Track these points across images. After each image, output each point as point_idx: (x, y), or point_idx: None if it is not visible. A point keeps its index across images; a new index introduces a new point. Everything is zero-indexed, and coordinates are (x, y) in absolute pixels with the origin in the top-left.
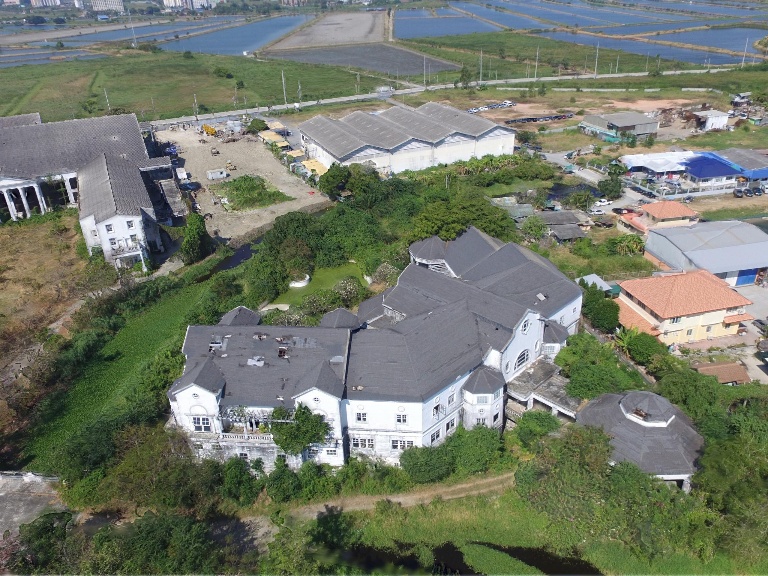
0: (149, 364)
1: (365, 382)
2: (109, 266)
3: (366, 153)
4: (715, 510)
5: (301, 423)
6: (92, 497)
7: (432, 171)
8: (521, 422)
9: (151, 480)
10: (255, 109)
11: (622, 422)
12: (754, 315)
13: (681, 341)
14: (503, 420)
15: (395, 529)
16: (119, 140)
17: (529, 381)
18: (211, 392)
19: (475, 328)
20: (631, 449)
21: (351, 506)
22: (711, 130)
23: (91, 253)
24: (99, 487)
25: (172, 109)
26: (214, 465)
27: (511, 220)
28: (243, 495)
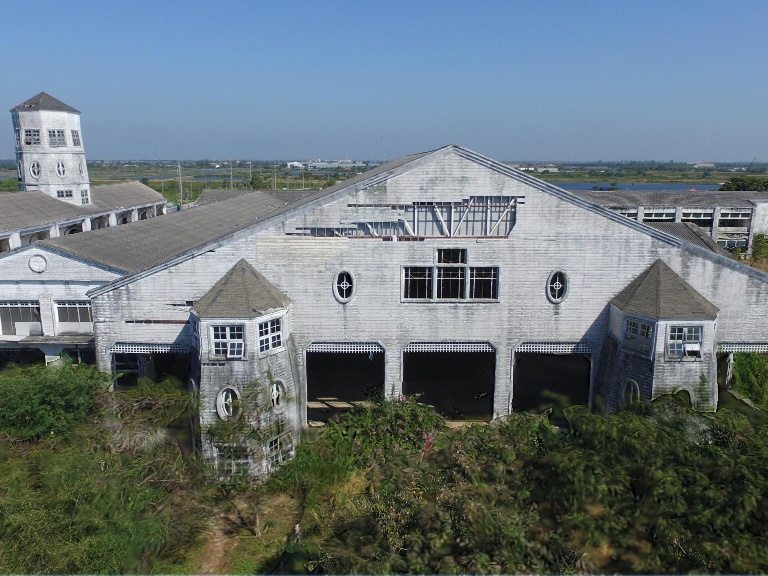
0: None
1: None
2: None
3: None
4: None
5: None
6: None
7: None
8: None
9: None
10: None
11: None
12: None
13: None
14: None
15: None
16: None
17: None
18: None
19: None
20: None
21: None
22: None
23: (750, 246)
24: None
25: None
26: None
27: None
28: None
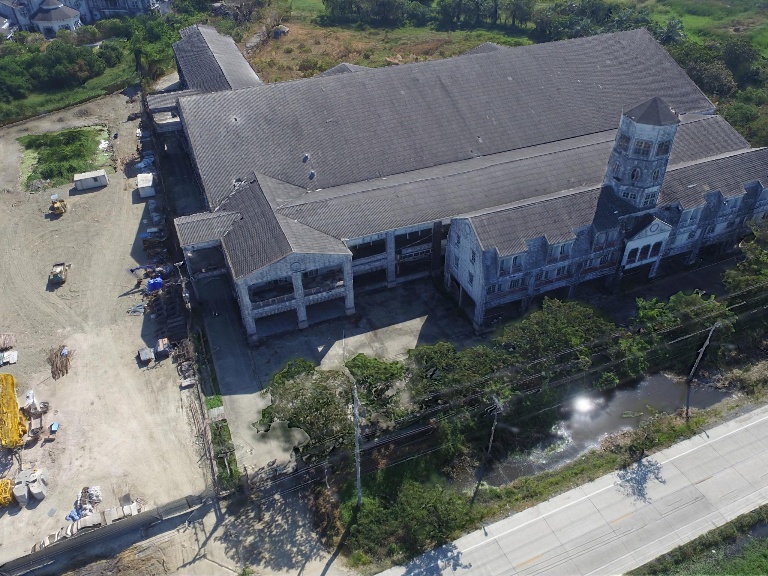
0: None
1: None
2: None
3: None
4: None
5: None
6: None
7: None
8: None
9: None
10: None
11: None
12: None
13: None
14: None
15: None
16: None
17: None
18: None
19: None
20: None
21: None
22: None
23: None
24: None
25: None
26: None
27: None
28: None
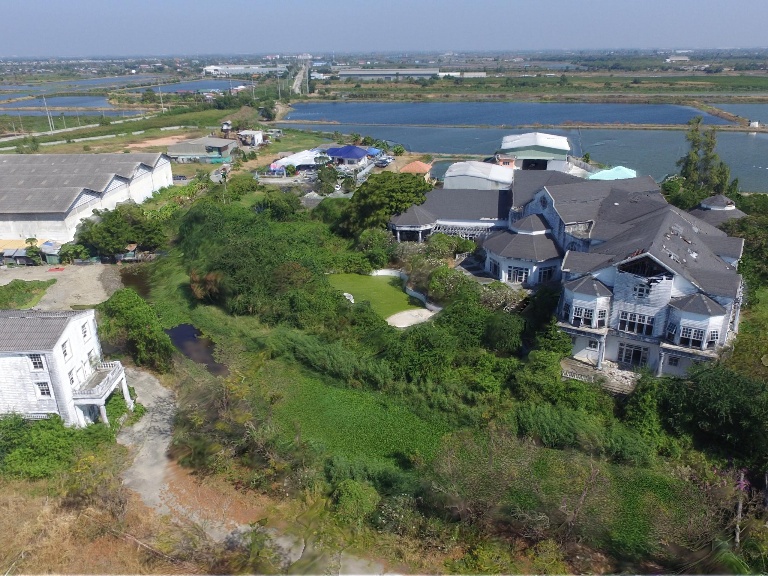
0: None
1: None
2: (81, 431)
3: (82, 201)
4: None
5: None
6: None
7: None
8: None
9: None
10: None
11: (727, 213)
12: None
13: None
14: None
15: None
16: None
17: None
18: None
19: None
20: None
21: None
22: (259, 145)
23: None
24: None
25: None
26: None
27: None
28: None
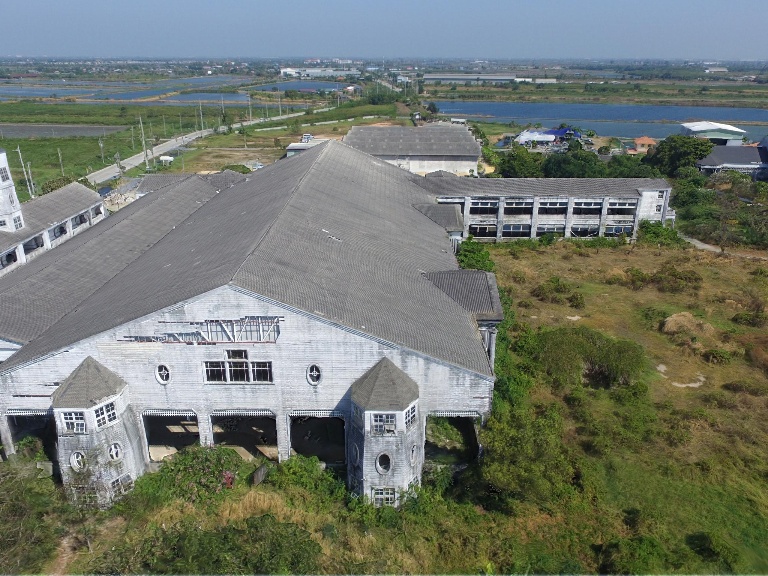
0: None
1: None
2: None
3: None
4: None
5: None
6: None
7: None
8: None
9: None
10: None
11: None
12: None
13: None
14: None
15: None
16: (383, 165)
17: None
18: None
19: None
20: None
21: None
22: None
23: None
24: None
25: None
26: None
27: (636, 158)
28: None
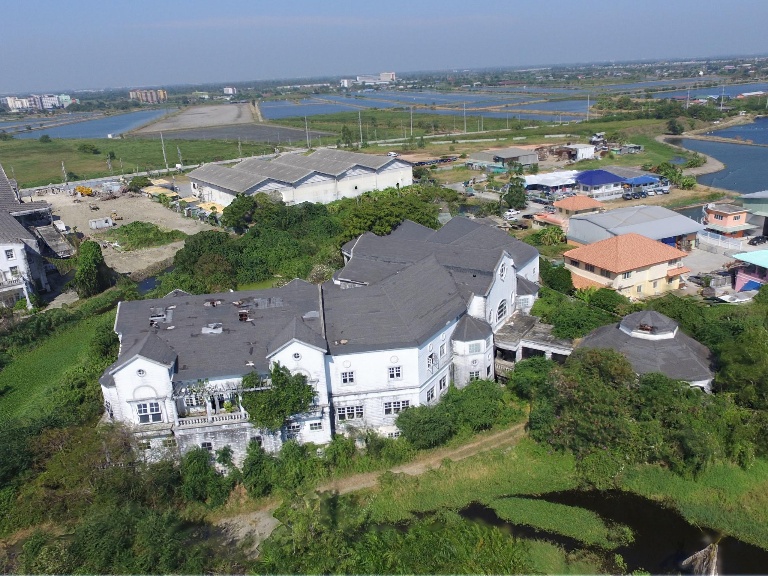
0: (54, 387)
1: (348, 335)
2: None
3: (268, 187)
4: (746, 408)
5: (280, 387)
6: (1, 527)
7: (337, 204)
8: (514, 375)
9: (91, 481)
10: (132, 174)
11: (628, 341)
12: (687, 273)
13: (635, 296)
14: (495, 375)
15: (408, 499)
16: None
17: (513, 331)
18: (162, 364)
19: (451, 279)
20: (646, 364)
21: (348, 487)
22: (582, 160)
23: None
24: (11, 512)
25: (35, 179)
26: (166, 468)
27: None
28: (211, 494)
